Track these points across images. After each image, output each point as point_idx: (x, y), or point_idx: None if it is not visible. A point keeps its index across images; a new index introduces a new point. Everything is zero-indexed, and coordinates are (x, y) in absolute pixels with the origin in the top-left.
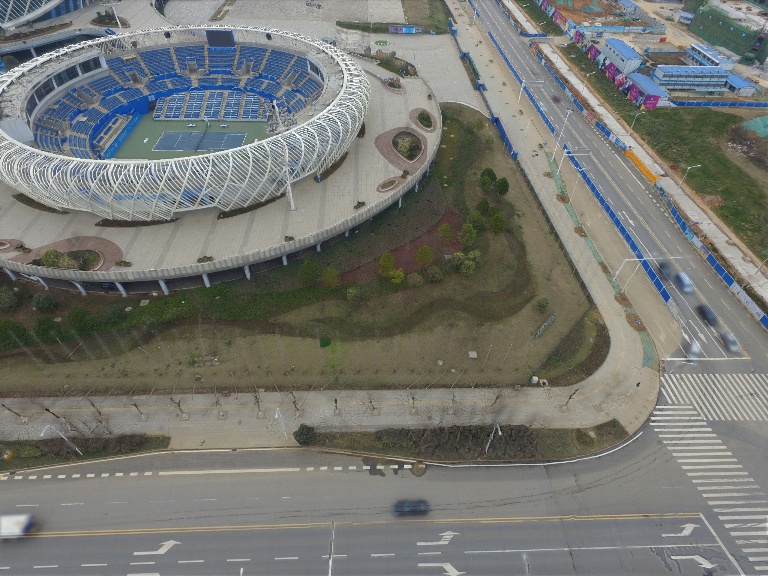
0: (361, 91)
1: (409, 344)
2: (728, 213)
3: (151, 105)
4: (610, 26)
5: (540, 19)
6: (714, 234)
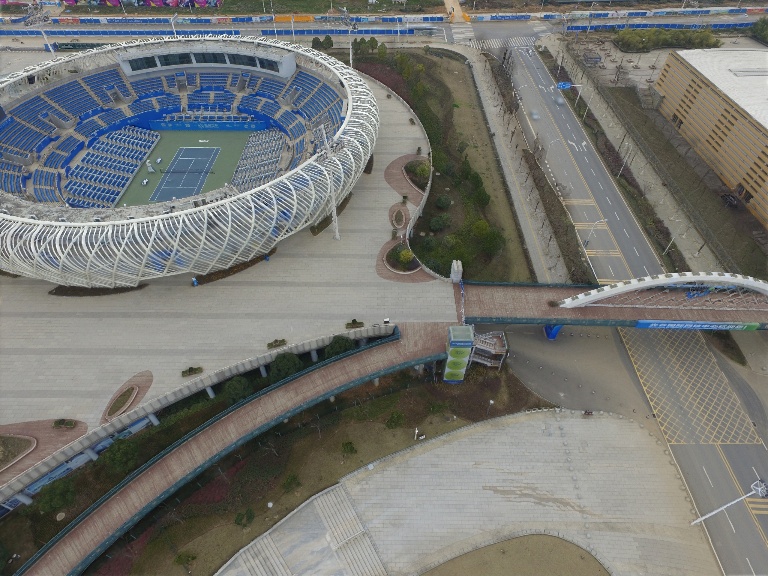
0: None
1: (453, 85)
2: None
3: None
4: None
5: None
6: None
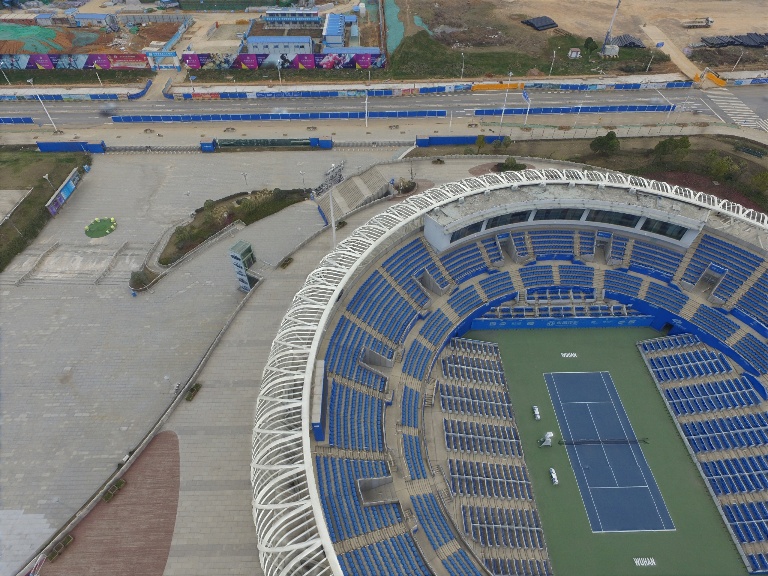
0: None
1: None
2: (551, 71)
3: None
4: (148, 41)
5: (75, 78)
6: (577, 82)
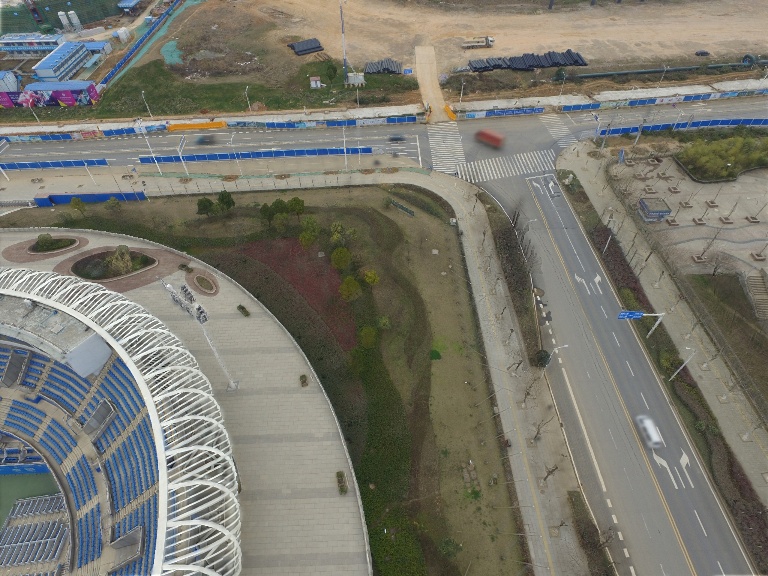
0: (3, 270)
1: (430, 291)
2: (276, 105)
3: None
4: None
5: None
6: (297, 117)
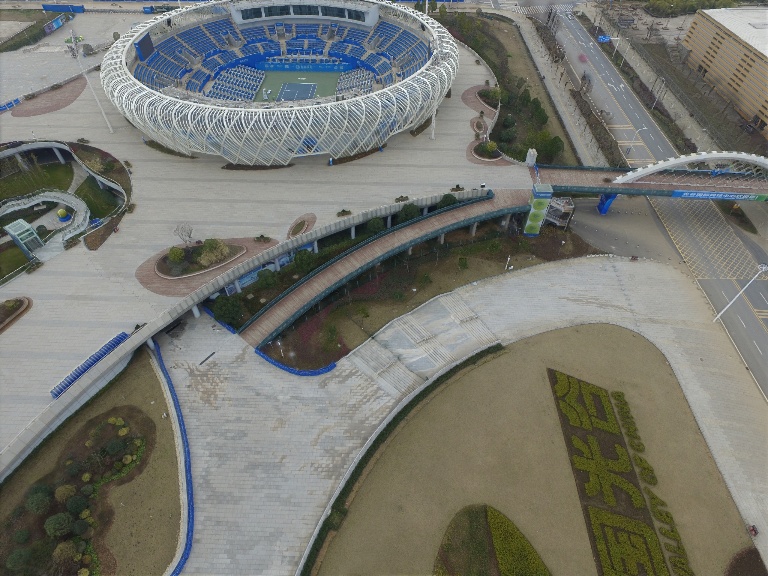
0: None
1: None
2: None
3: None
4: None
5: None
6: None
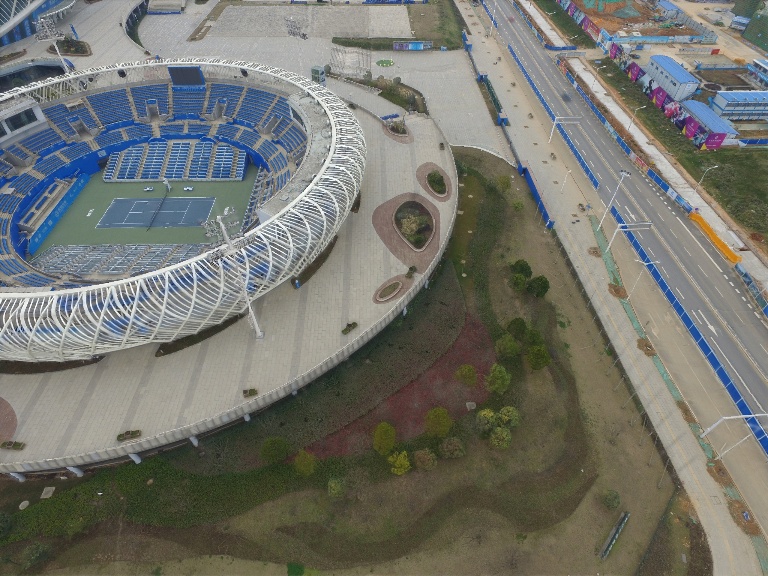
0: (353, 157)
1: (417, 574)
2: None
3: (103, 160)
4: (650, 34)
5: (567, 27)
6: None
